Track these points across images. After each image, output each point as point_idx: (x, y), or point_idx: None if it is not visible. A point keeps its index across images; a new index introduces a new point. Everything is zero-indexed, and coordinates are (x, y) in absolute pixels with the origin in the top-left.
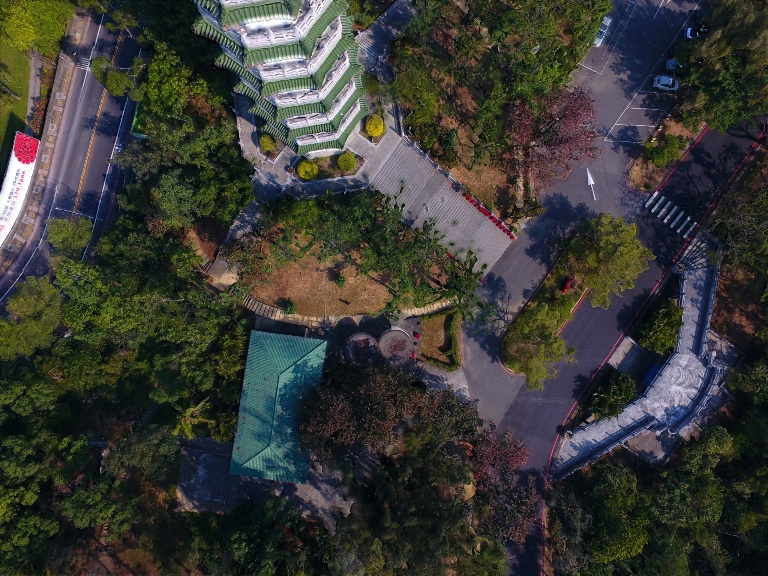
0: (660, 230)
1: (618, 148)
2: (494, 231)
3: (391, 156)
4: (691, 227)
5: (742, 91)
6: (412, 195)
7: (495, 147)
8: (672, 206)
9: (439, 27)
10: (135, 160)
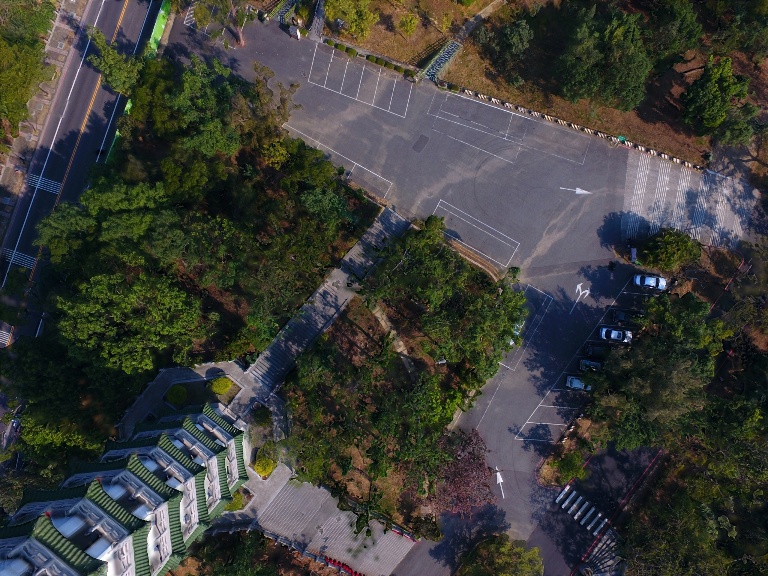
0: (570, 527)
1: (529, 446)
2: (396, 538)
3: (282, 490)
4: (602, 524)
5: (645, 433)
6: (306, 519)
7: (400, 451)
8: (583, 502)
9: (345, 333)
10: (7, 500)
